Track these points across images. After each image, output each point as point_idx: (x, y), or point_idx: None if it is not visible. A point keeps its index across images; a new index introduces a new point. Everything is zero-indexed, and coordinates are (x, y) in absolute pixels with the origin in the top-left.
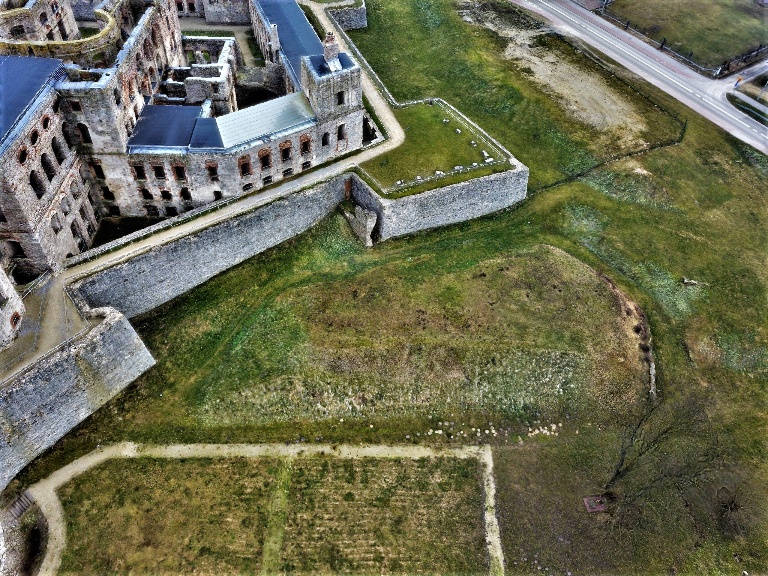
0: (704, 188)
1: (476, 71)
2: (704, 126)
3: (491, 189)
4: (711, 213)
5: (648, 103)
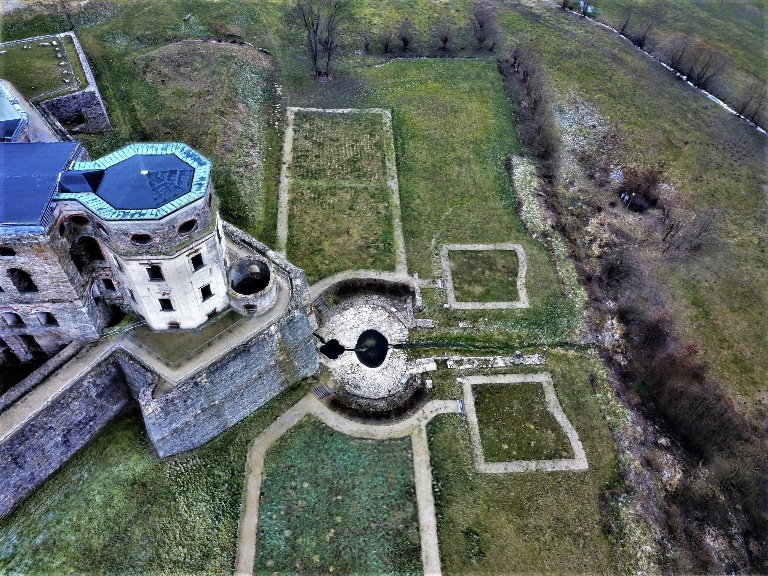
0: None
1: None
2: None
3: None
4: None
5: None
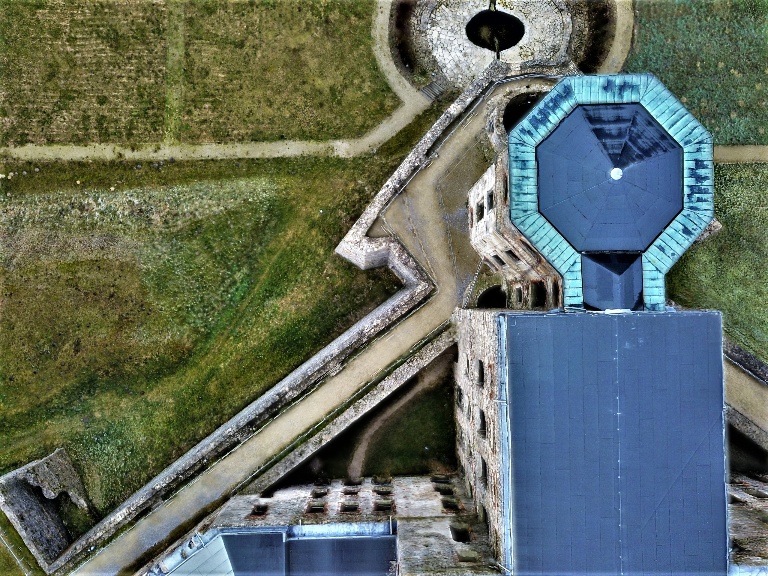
0: None
1: None
2: None
3: None
4: None
5: None
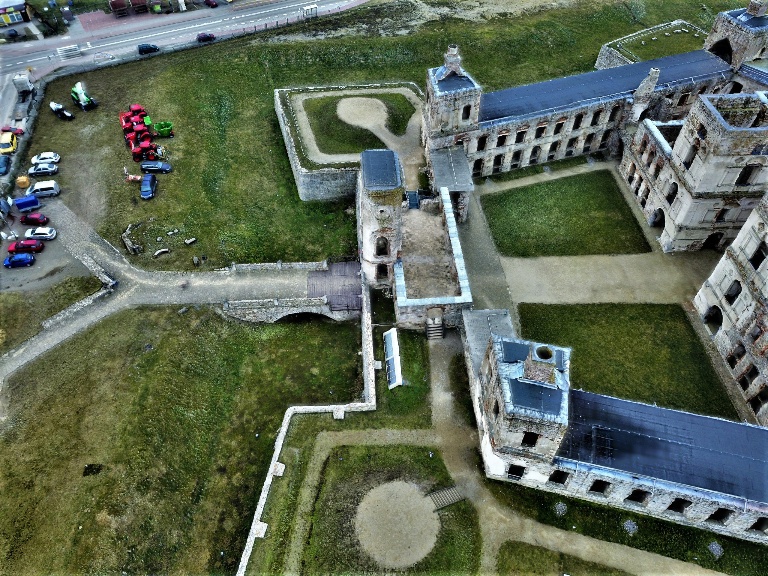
0: None
1: (513, 38)
2: None
3: None
4: None
5: None
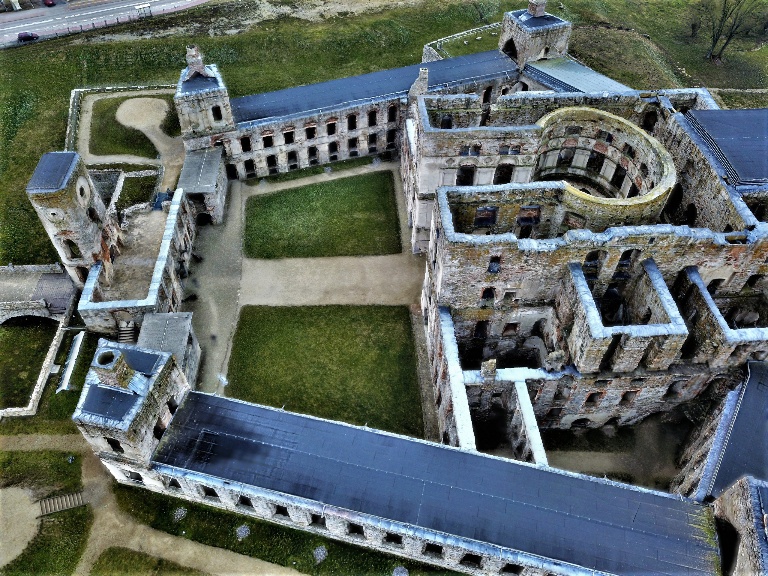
0: None
1: (345, 37)
2: None
3: None
4: None
5: None
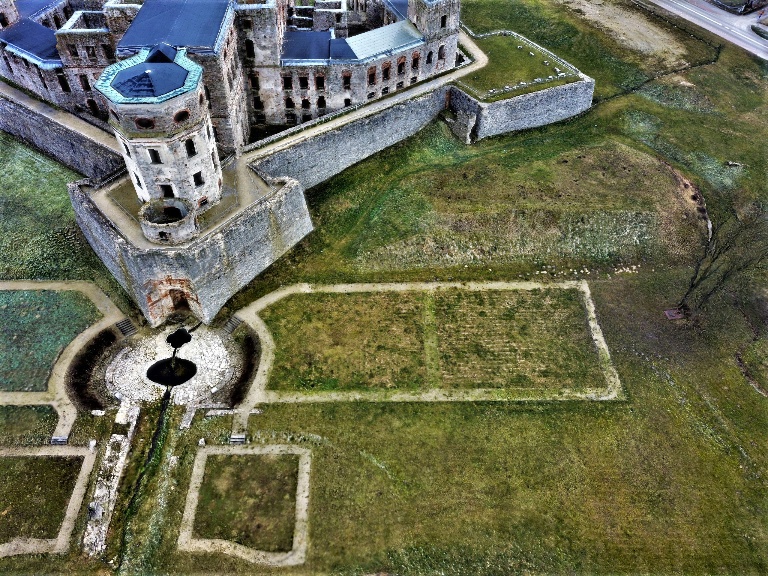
0: (739, 96)
1: (534, 13)
2: (735, 50)
3: (565, 97)
4: (746, 115)
5: (685, 34)
